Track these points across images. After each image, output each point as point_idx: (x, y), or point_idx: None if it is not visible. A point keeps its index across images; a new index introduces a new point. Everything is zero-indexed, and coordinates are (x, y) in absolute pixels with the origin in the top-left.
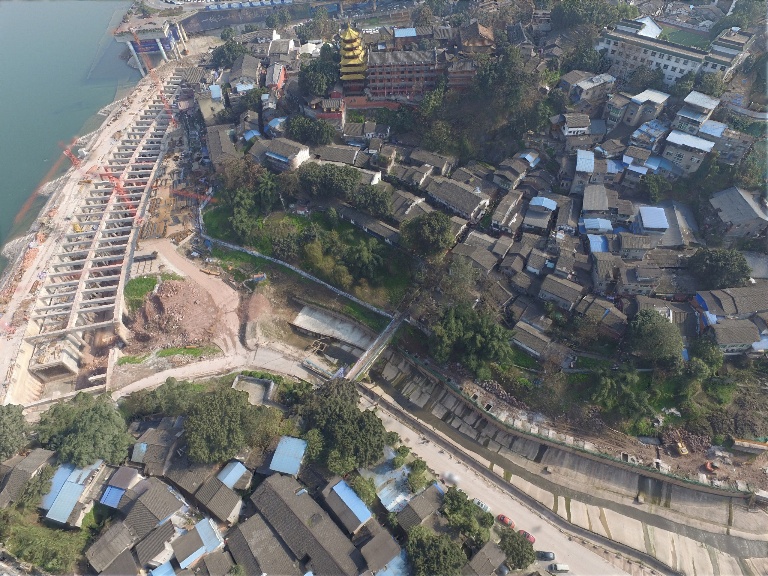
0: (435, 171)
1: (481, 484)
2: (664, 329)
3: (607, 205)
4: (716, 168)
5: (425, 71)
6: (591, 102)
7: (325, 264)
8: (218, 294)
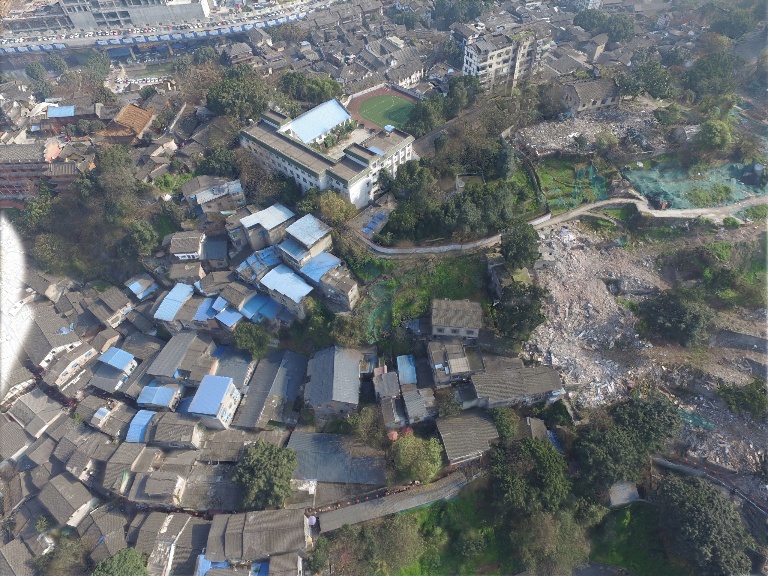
0: (43, 296)
1: None
2: None
3: (178, 367)
4: (316, 320)
5: (41, 169)
6: (217, 217)
7: None
8: None
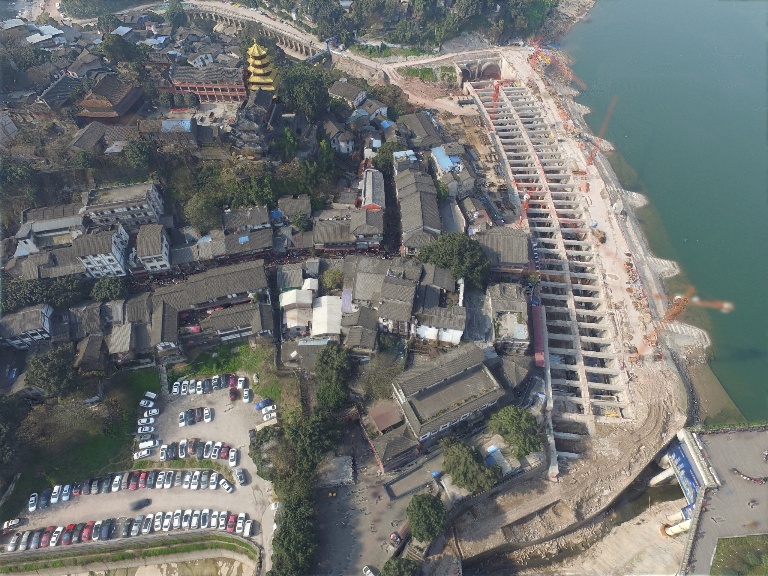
0: None
1: (277, 26)
2: None
3: None
4: None
5: None
6: None
7: None
8: None
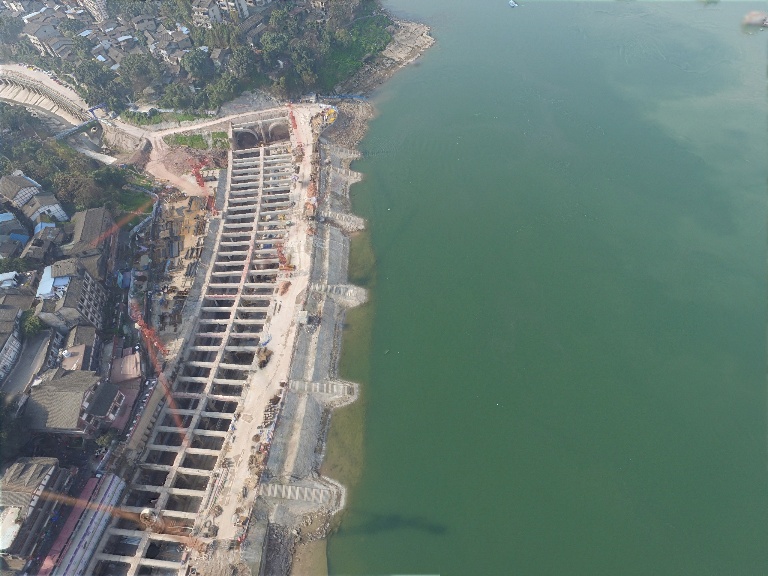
0: None
1: (60, 91)
2: None
3: None
4: None
5: None
6: None
7: None
8: (160, 169)
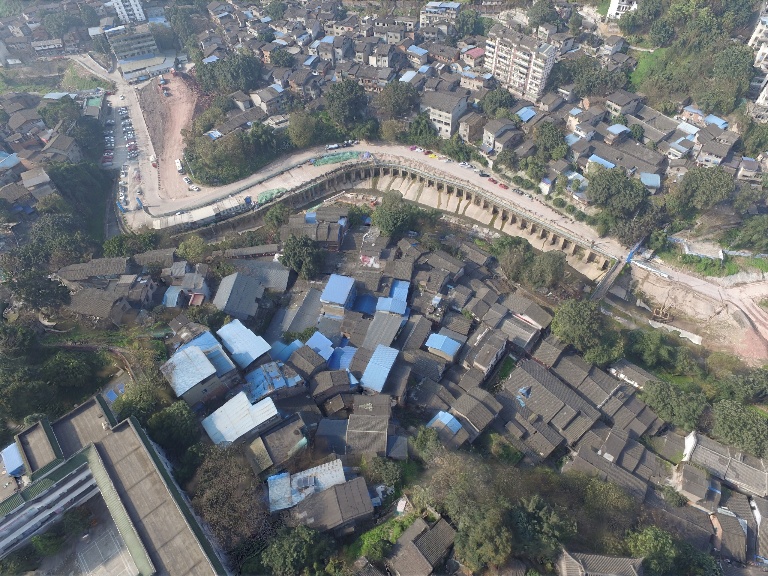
0: None
1: (516, 201)
2: (398, 191)
3: None
4: None
5: None
6: None
7: (699, 345)
8: None
